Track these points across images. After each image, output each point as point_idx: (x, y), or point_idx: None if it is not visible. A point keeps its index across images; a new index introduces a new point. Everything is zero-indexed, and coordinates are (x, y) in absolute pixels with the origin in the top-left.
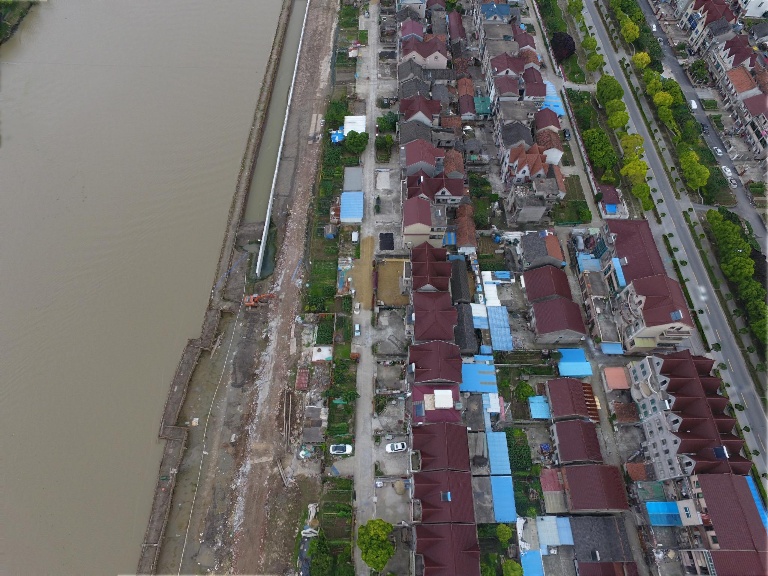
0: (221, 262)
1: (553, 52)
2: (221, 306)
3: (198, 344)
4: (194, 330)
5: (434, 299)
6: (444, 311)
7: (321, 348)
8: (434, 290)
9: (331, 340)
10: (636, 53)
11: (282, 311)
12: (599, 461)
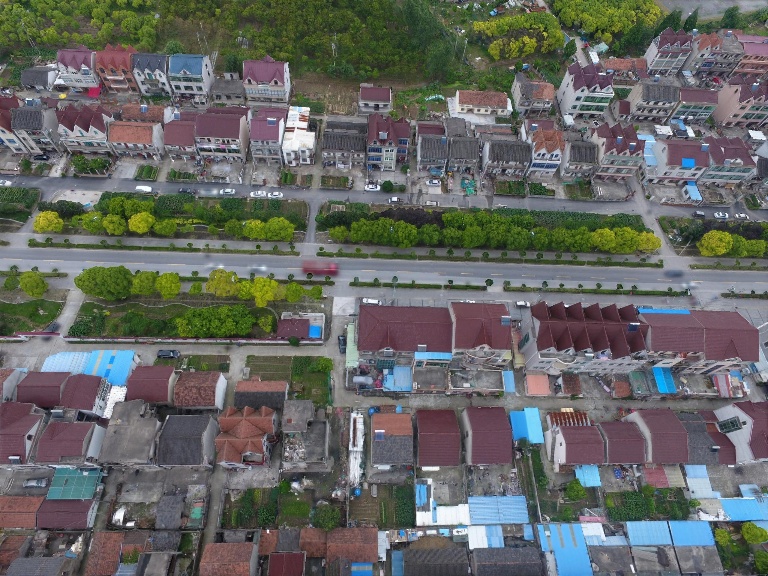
0: None
1: None
2: None
3: None
4: None
5: None
6: None
7: None
8: None
9: None
10: (21, 221)
11: None
12: (636, 427)
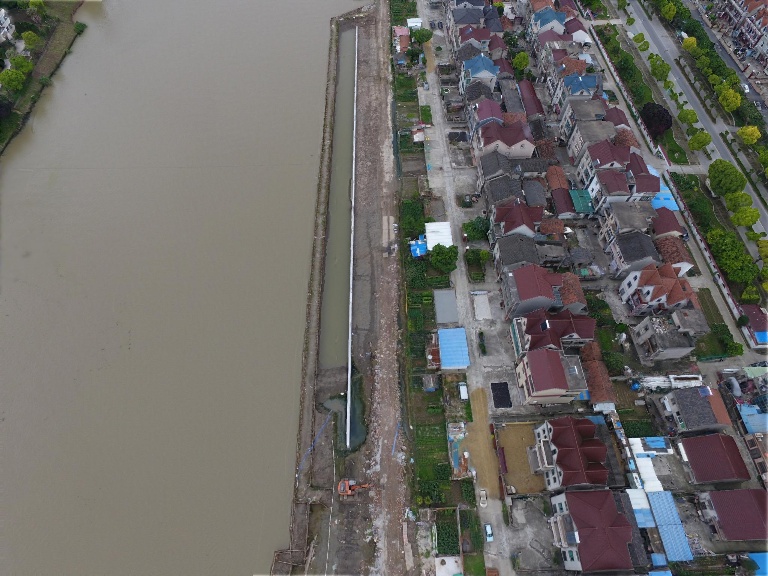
0: (302, 431)
1: (645, 126)
2: (309, 497)
3: (288, 559)
4: (280, 535)
5: (601, 510)
6: (615, 527)
7: (445, 559)
8: (591, 487)
9: (457, 548)
10: (737, 123)
11: (387, 503)
12: None
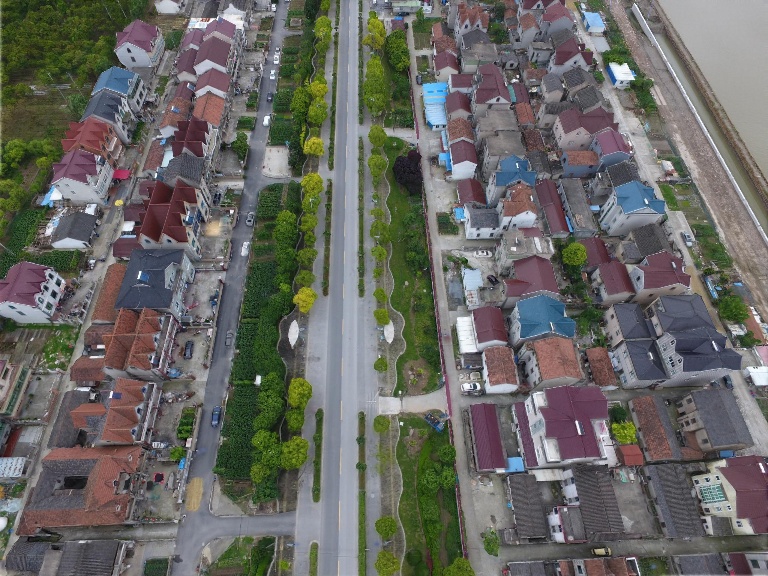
0: None
1: None
2: None
3: None
4: None
5: None
6: None
7: None
8: None
9: None
10: None
11: None
12: None
